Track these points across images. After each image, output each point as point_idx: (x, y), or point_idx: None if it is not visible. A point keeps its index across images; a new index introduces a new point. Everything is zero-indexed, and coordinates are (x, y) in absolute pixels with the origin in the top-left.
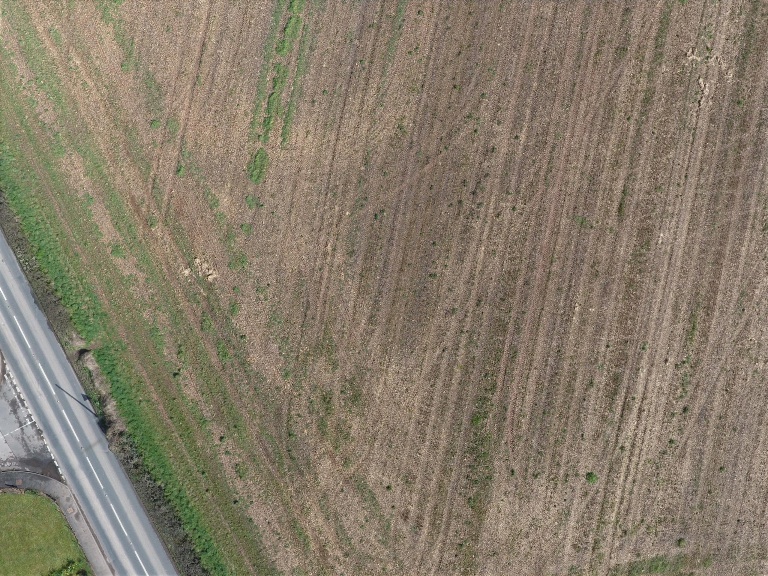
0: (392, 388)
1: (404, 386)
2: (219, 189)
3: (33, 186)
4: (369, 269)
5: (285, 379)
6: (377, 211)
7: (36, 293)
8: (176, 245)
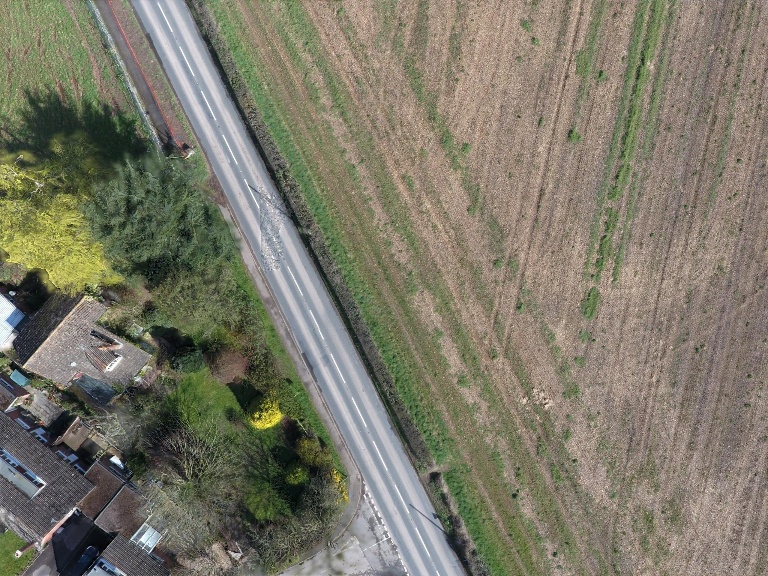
0: (708, 509)
1: (719, 507)
2: (555, 324)
3: (389, 321)
4: (689, 399)
5: (612, 500)
6: (698, 346)
7: (400, 423)
8: (515, 376)
